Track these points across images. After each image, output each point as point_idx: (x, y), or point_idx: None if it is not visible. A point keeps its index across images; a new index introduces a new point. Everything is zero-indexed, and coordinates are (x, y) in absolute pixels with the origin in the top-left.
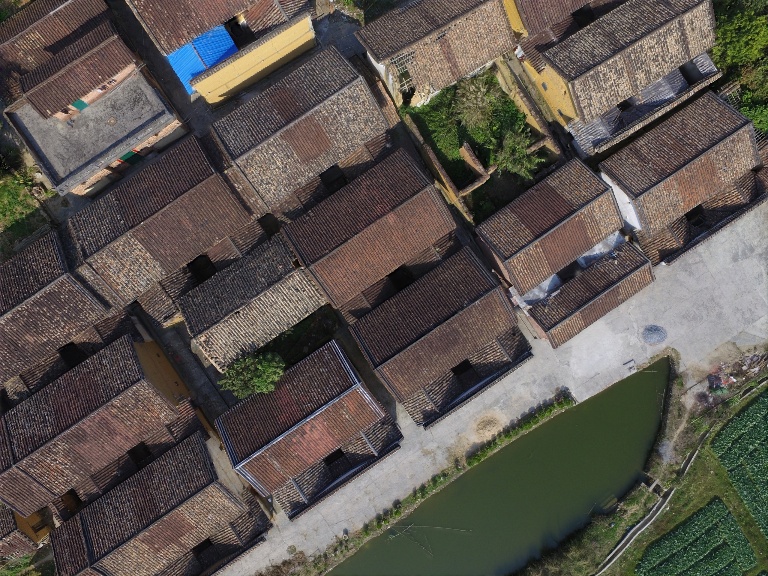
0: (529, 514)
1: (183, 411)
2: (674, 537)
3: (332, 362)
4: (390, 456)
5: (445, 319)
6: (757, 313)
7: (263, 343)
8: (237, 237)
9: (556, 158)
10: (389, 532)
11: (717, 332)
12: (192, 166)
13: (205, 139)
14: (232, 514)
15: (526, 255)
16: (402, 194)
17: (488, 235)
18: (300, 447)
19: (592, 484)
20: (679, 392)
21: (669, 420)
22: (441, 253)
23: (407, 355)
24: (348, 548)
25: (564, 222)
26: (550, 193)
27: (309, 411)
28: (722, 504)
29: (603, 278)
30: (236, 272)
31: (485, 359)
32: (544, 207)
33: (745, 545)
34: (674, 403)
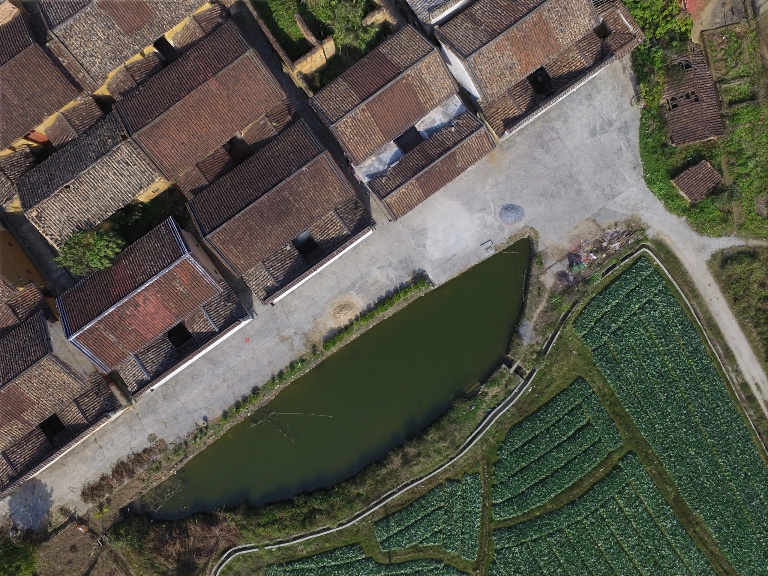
0: (391, 400)
1: (29, 294)
2: (536, 418)
3: (167, 236)
4: (247, 343)
5: (273, 187)
6: (617, 189)
7: (99, 220)
8: (73, 118)
9: (395, 30)
10: (251, 420)
11: (576, 209)
12: (14, 40)
13: (34, 18)
14: (74, 391)
15: (354, 120)
16: (224, 61)
17: (319, 104)
18: (136, 321)
19: (455, 369)
20: (538, 272)
21: (529, 300)
22: (278, 128)
23: (237, 224)
24: (208, 435)
25: (390, 84)
26: (380, 59)
27: (141, 282)
28: (585, 384)
29: (440, 146)
30: (70, 150)
31: (327, 235)
32: (373, 73)
33: (609, 425)
34: (534, 283)
